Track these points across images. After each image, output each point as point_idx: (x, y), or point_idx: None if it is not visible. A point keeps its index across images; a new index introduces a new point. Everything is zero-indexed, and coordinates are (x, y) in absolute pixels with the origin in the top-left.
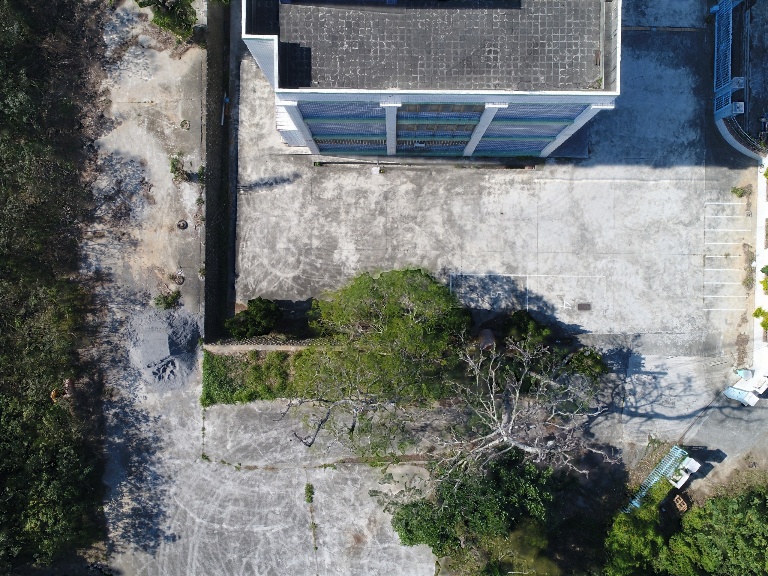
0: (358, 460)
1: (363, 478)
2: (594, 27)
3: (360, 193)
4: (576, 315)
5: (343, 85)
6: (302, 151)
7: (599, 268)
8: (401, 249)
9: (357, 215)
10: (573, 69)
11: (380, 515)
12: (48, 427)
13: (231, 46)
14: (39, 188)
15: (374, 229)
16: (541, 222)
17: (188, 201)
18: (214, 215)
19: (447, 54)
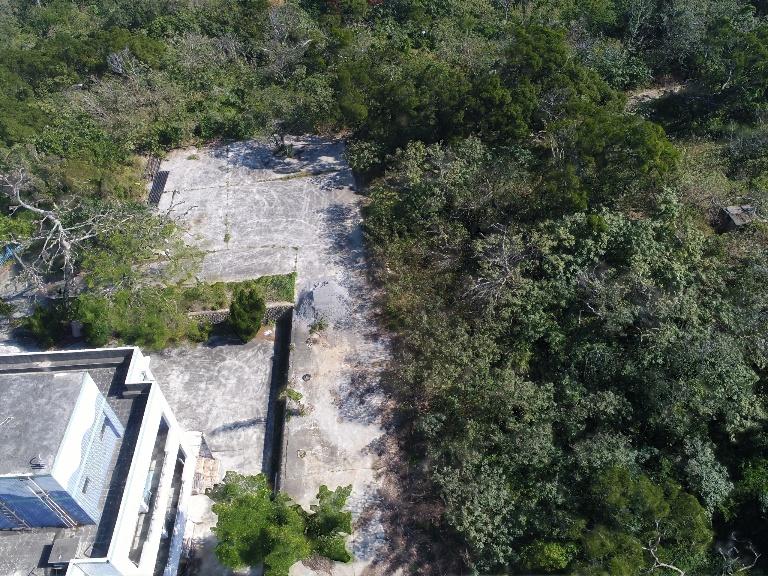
0: None
1: None
2: None
3: None
4: (3, 352)
5: None
6: None
7: None
8: None
9: None
10: None
11: None
12: None
13: None
14: None
15: None
16: None
17: None
18: None
19: None
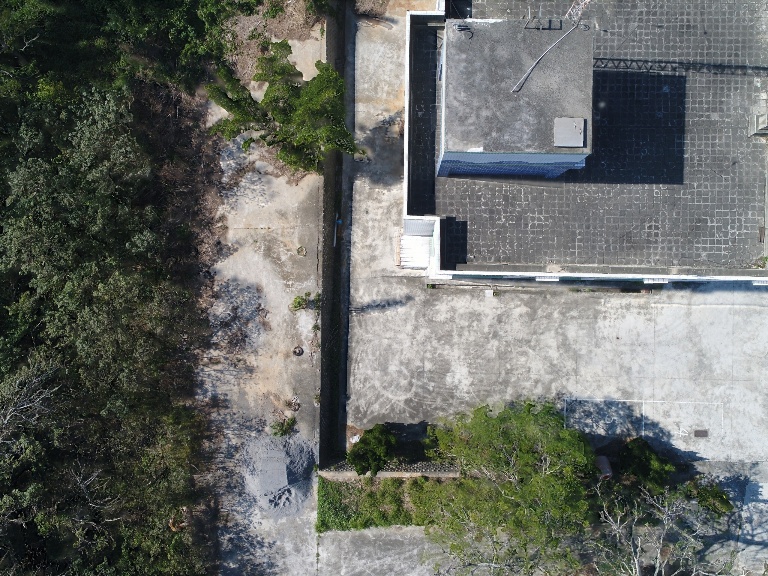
0: None
1: None
2: (759, 203)
3: (473, 316)
4: (693, 442)
5: (499, 259)
6: (415, 274)
7: (717, 395)
8: (515, 373)
9: (470, 338)
10: (736, 246)
11: None
12: (174, 565)
13: (344, 167)
14: (163, 323)
15: (487, 352)
16: (658, 347)
17: (304, 327)
18: (327, 338)
19: (606, 229)
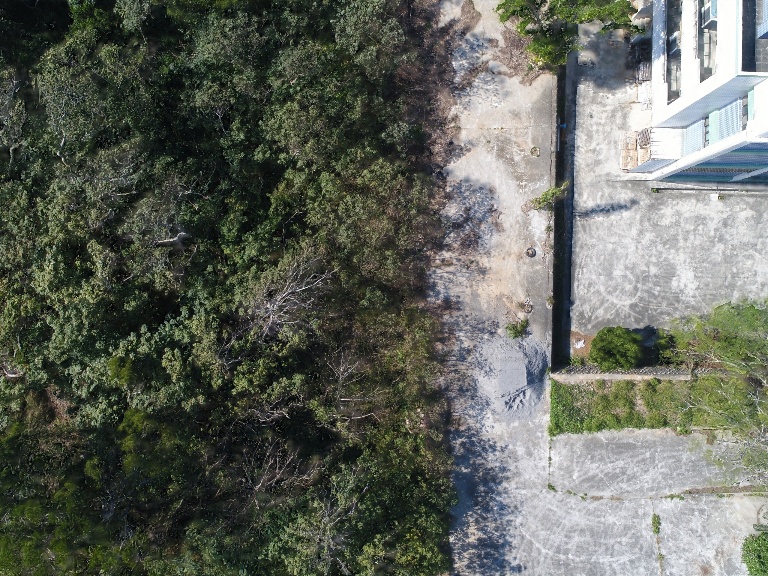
0: (704, 490)
1: (710, 509)
2: None
3: (699, 220)
4: None
5: None
6: (641, 177)
7: None
8: (741, 276)
9: (696, 242)
10: None
11: (727, 546)
12: (429, 460)
13: (567, 71)
14: None
15: (713, 256)
16: None
17: (537, 229)
18: (554, 242)
19: None
